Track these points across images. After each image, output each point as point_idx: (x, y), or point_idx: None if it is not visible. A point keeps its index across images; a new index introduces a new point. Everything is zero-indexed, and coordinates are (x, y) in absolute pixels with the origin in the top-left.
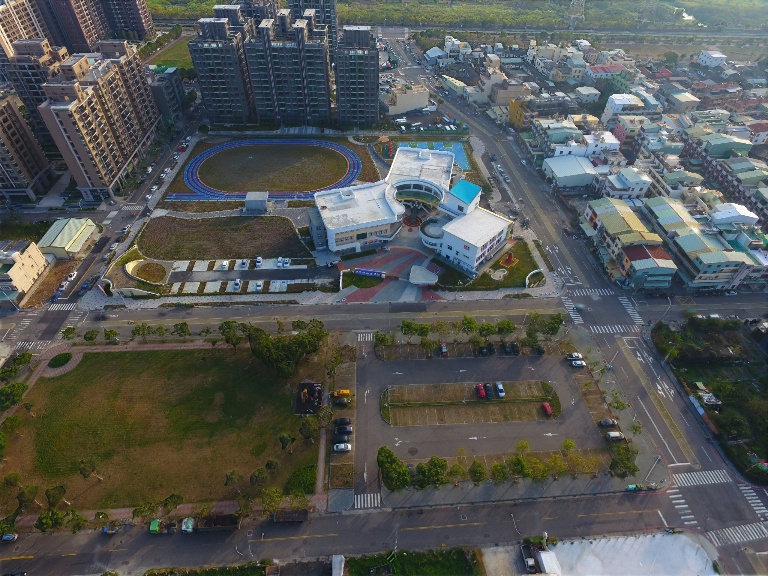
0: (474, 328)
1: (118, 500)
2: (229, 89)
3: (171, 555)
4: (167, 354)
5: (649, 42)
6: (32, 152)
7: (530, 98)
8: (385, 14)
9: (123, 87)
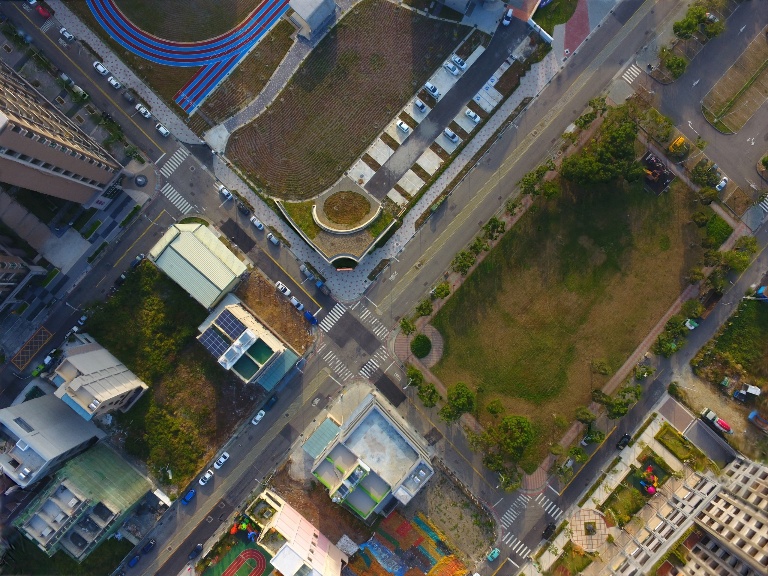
0: None
1: (620, 359)
2: None
3: (692, 345)
4: (496, 255)
5: None
6: None
7: None
8: None
9: None
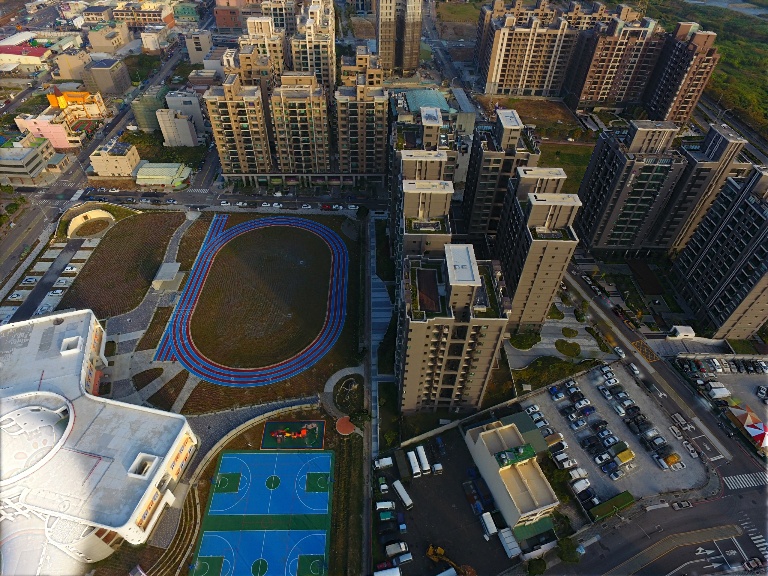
0: None
1: None
2: None
3: None
4: None
5: None
6: None
7: None
8: None
9: (321, 120)
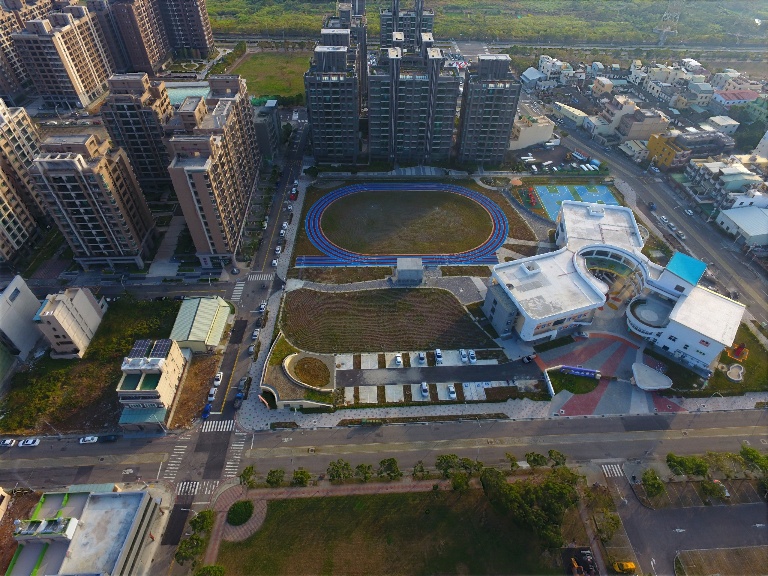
0: (765, 466)
1: None
2: (343, 126)
3: None
4: (374, 501)
5: (752, 59)
6: (140, 211)
7: (677, 133)
8: (451, 26)
9: (238, 130)
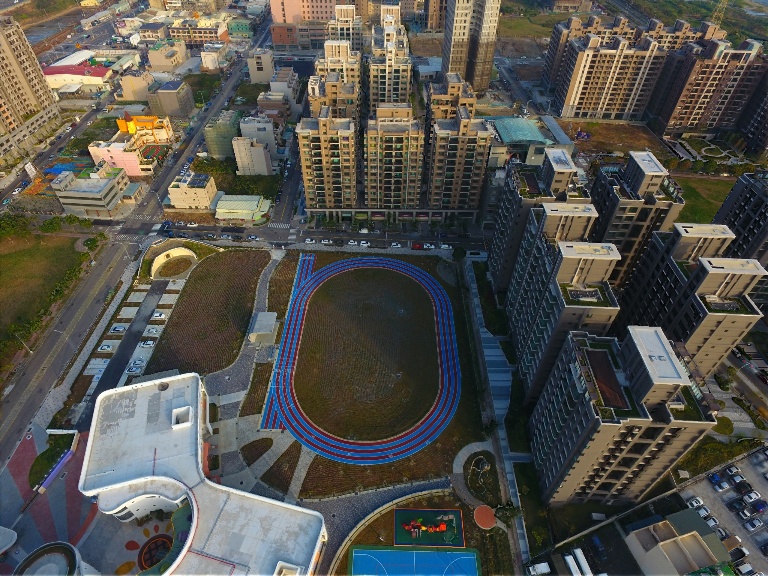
0: None
1: None
2: None
3: None
4: None
5: None
6: None
7: None
8: None
9: (417, 155)
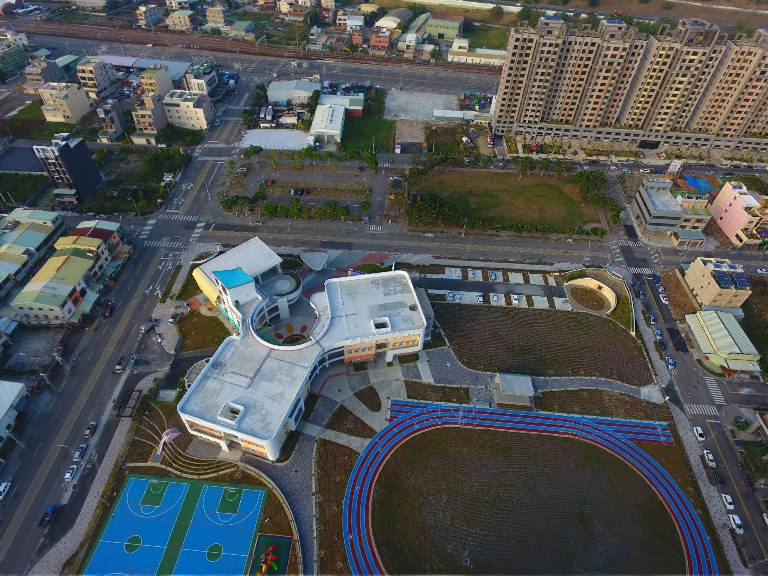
0: None
1: None
2: None
3: None
4: None
5: None
6: None
7: None
8: None
9: None
